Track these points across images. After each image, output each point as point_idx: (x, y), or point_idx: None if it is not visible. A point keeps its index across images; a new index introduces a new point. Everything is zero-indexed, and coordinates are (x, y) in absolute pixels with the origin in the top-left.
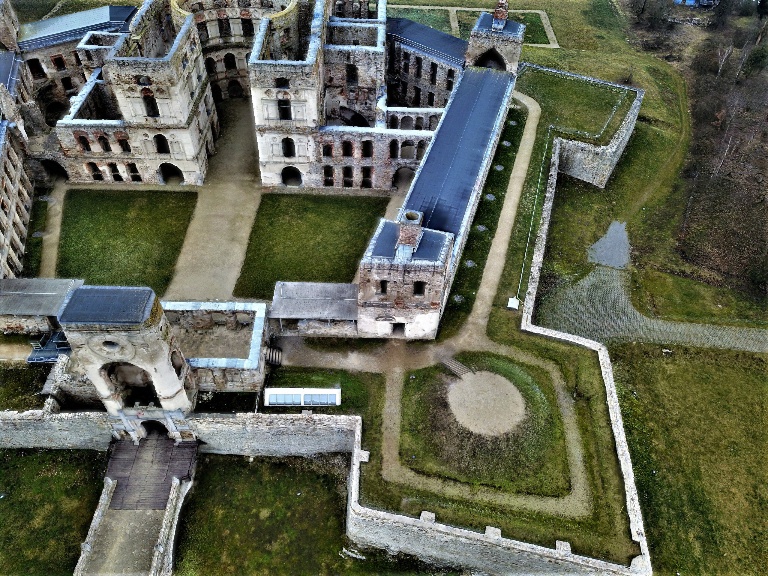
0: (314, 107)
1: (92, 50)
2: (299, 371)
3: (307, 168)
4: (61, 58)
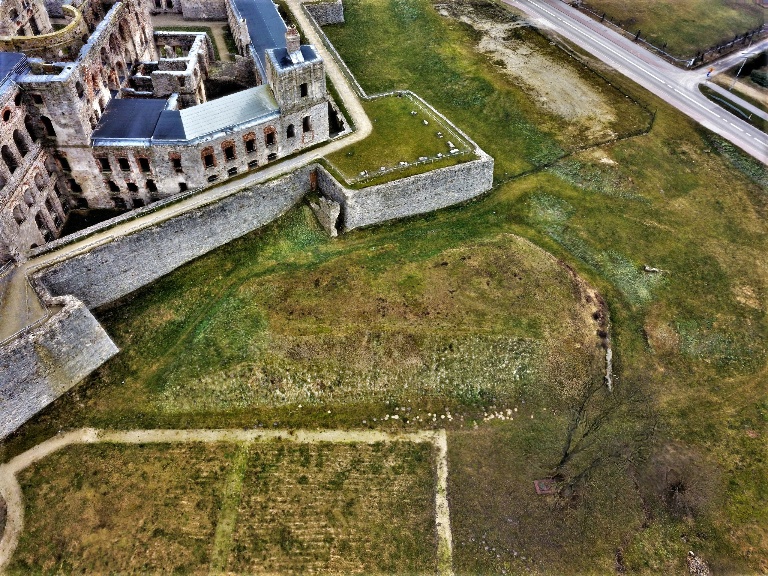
0: None
1: None
2: None
3: None
4: None
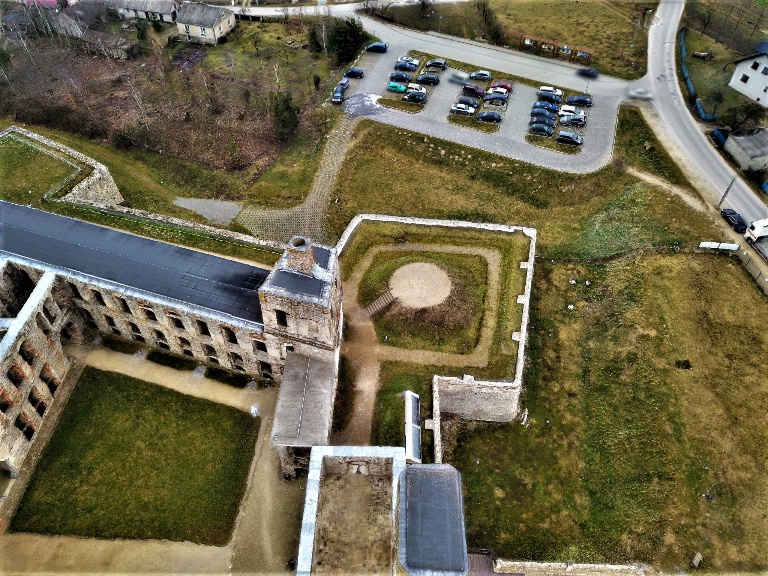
0: None
1: None
2: (376, 435)
3: (5, 448)
4: None
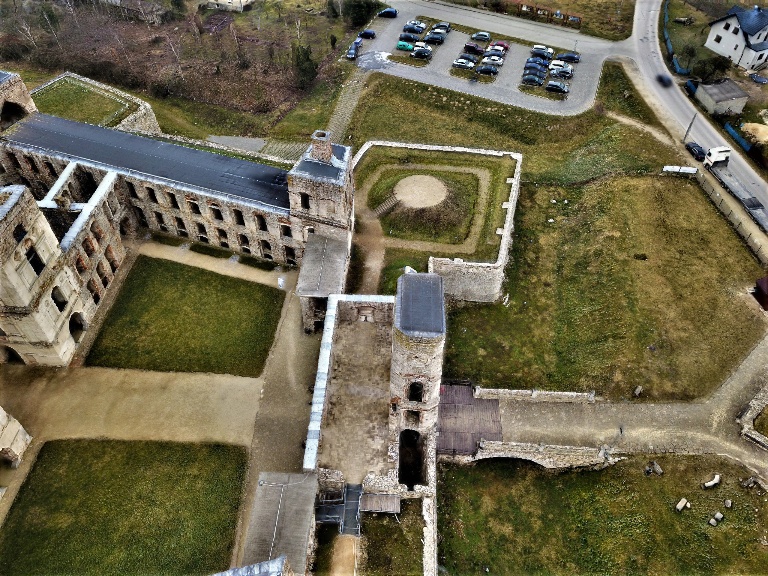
0: (50, 232)
1: None
2: None
3: (80, 303)
4: None
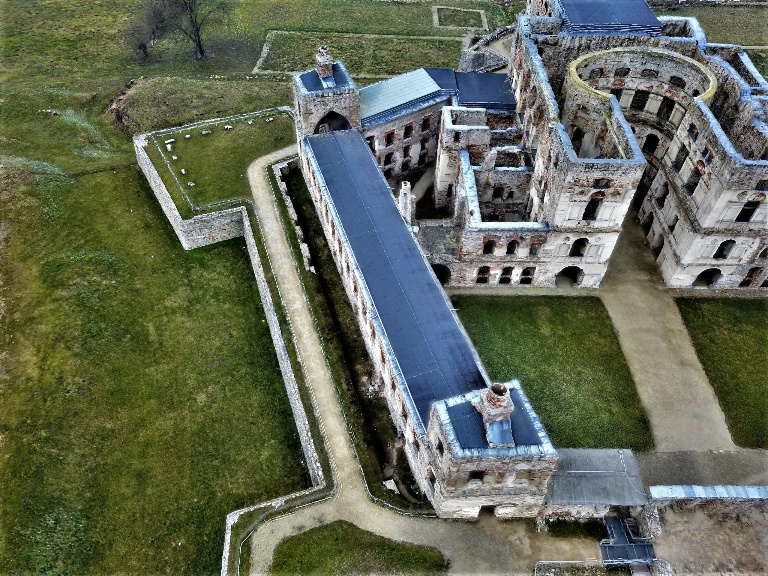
0: None
1: (464, 131)
2: None
3: (732, 270)
4: (393, 133)
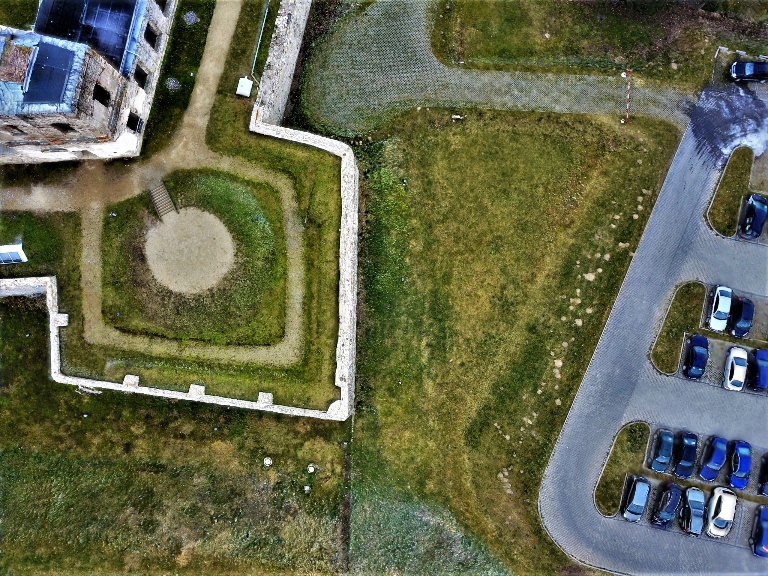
0: None
1: None
2: None
3: None
4: None
